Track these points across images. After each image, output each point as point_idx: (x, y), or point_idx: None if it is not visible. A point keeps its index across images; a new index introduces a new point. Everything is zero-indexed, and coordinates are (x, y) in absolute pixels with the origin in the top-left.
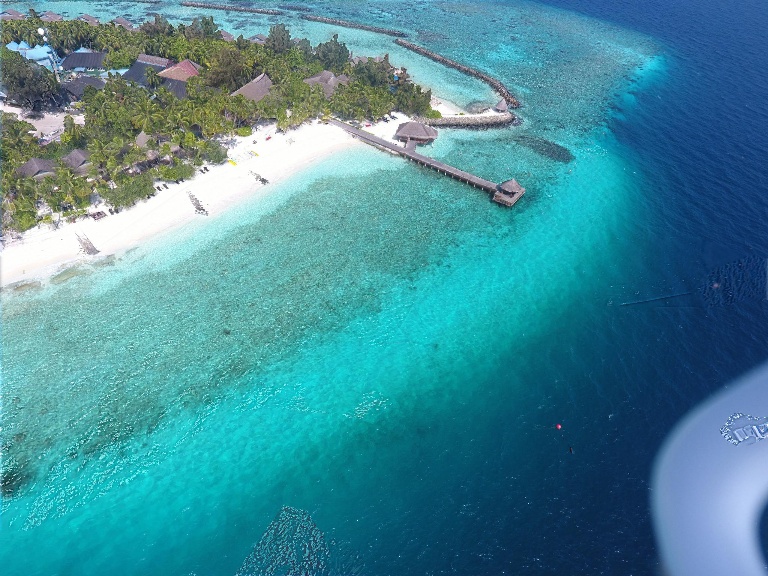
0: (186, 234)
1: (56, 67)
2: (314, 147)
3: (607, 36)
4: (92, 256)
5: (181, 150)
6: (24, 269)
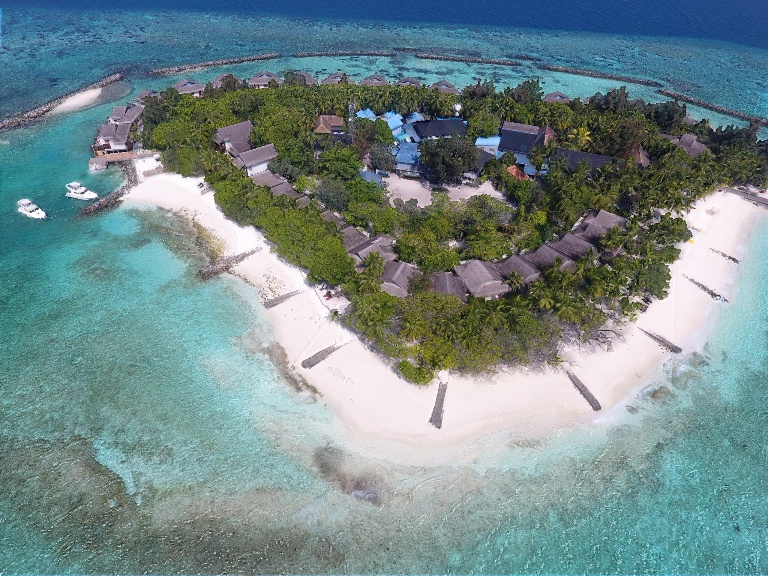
0: (733, 325)
1: None
2: (734, 218)
3: None
4: (680, 354)
5: None
6: (634, 372)
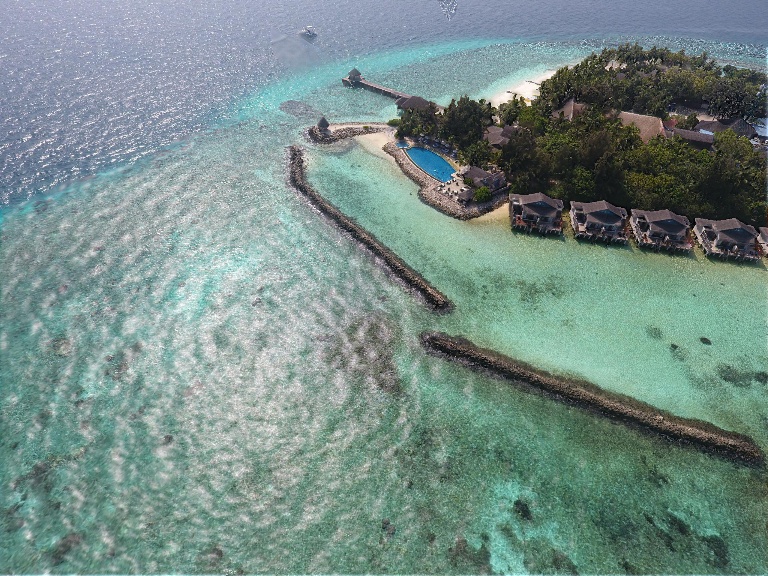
0: None
1: None
2: None
3: None
4: None
5: None
6: None
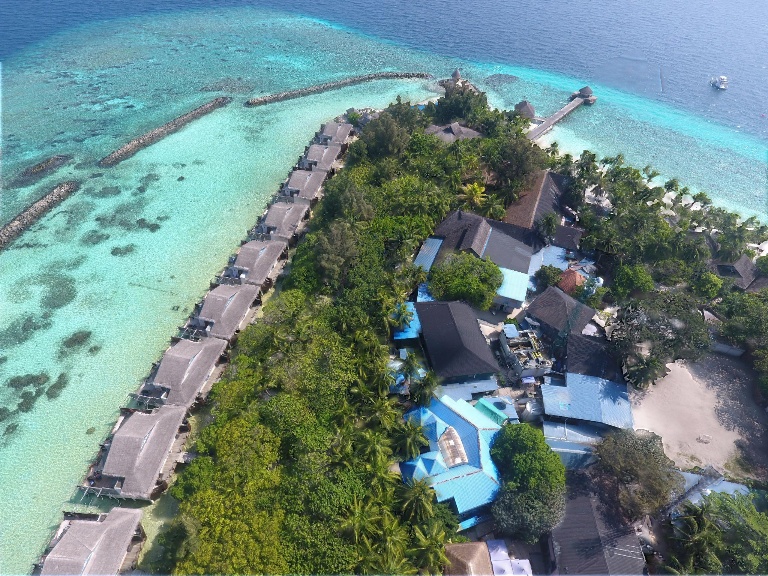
0: None
1: None
2: None
3: (241, 18)
4: None
5: None
6: None
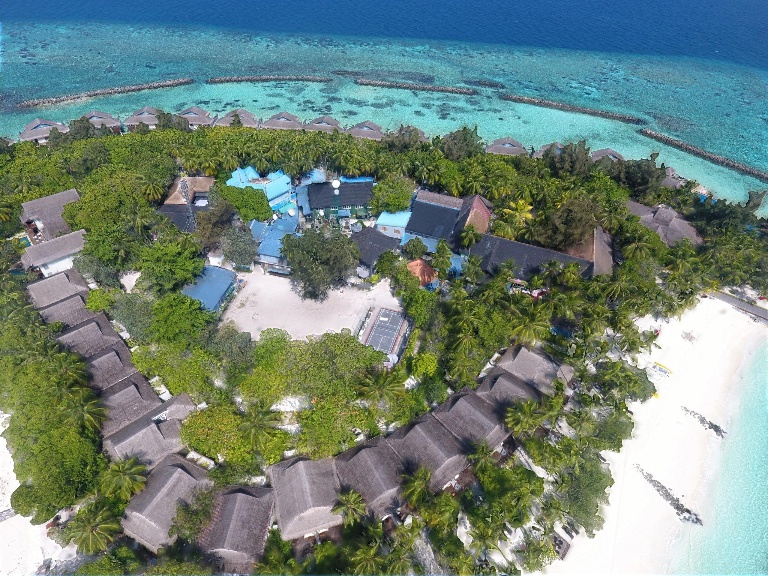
0: None
1: (290, 198)
2: (722, 345)
3: None
4: None
5: (574, 373)
6: None
